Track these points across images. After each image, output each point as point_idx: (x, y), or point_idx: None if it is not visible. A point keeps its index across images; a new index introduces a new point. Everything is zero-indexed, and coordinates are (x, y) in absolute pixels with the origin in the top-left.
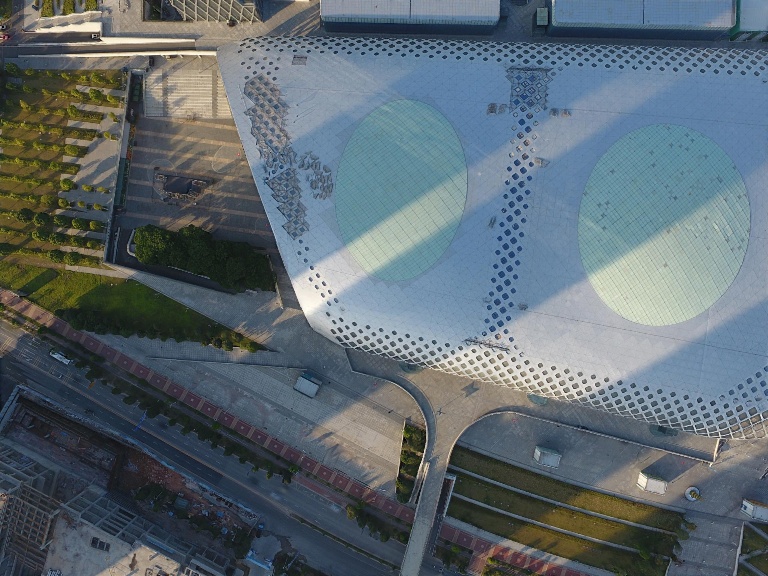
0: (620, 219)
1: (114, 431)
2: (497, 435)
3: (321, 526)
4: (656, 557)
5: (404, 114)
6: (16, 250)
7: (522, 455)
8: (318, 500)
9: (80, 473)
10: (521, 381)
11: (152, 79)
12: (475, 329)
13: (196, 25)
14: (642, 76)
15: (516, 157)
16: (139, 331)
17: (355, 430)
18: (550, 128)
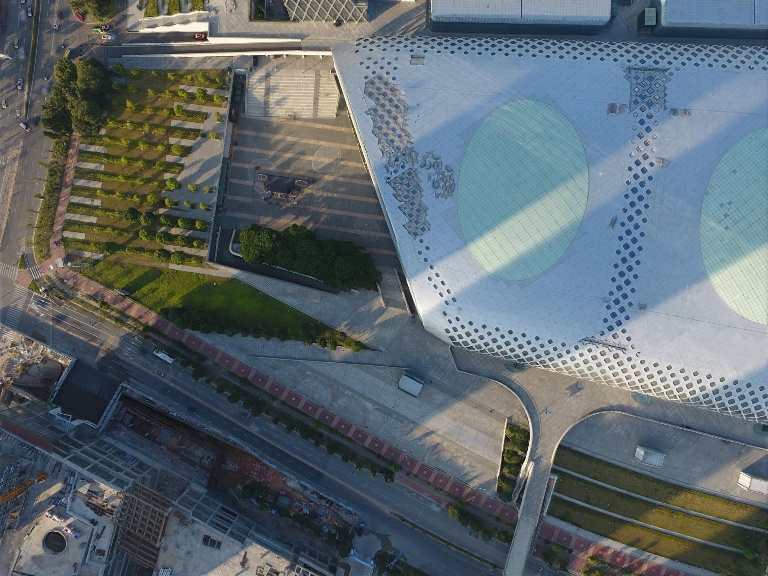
0: (743, 219)
1: (216, 429)
2: (598, 434)
3: (421, 525)
4: (760, 556)
5: (525, 114)
6: (120, 249)
7: (623, 454)
8: (418, 499)
9: (180, 471)
10: (634, 380)
11: (255, 79)
12: (593, 328)
13: (302, 25)
14: (759, 76)
15: (637, 157)
16: (243, 330)
17: (456, 429)
18: (670, 128)
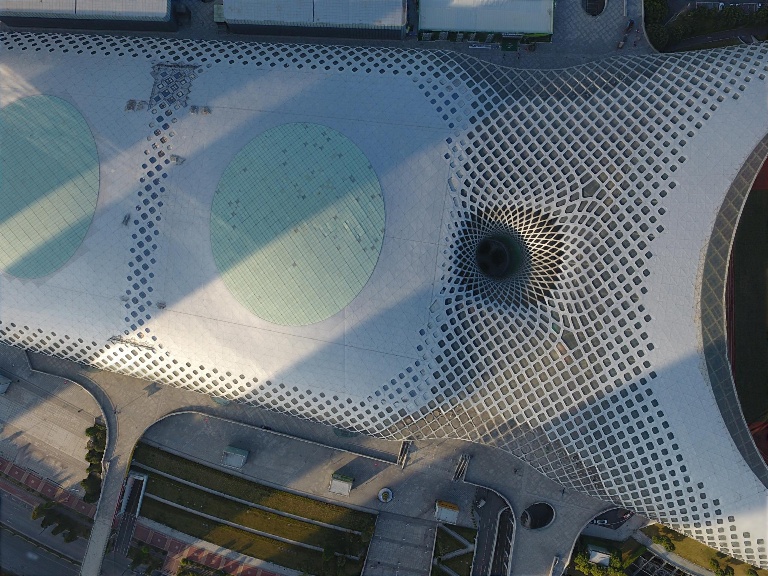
0: (249, 218)
1: None
2: (189, 435)
3: (13, 526)
4: None
5: (38, 110)
6: None
7: (214, 455)
8: (10, 500)
9: None
10: (177, 381)
11: None
12: (117, 328)
13: None
14: (291, 74)
15: (152, 154)
16: None
17: (46, 429)
18: (188, 125)
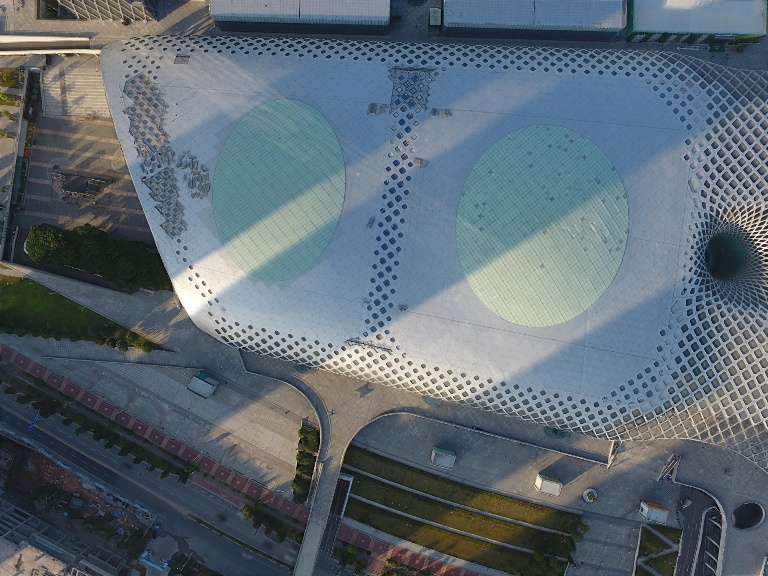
0: (497, 220)
1: (10, 431)
2: (394, 436)
3: (219, 527)
4: (550, 559)
5: (283, 114)
6: None
7: (419, 456)
8: (216, 501)
9: None
10: (407, 382)
11: (49, 77)
12: (356, 329)
13: (91, 24)
14: (525, 77)
15: (395, 157)
16: (33, 330)
17: (252, 430)
18: (430, 128)
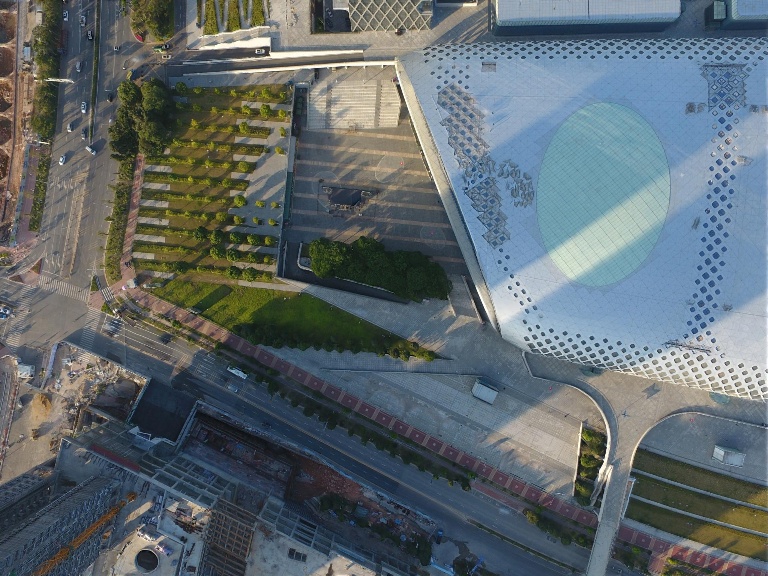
0: None
1: (292, 443)
2: (675, 435)
3: (498, 531)
4: None
5: (602, 117)
6: (189, 268)
7: (701, 455)
8: (495, 505)
9: (257, 485)
10: (717, 382)
11: (316, 92)
12: (676, 332)
13: (364, 35)
14: None
15: (718, 156)
16: (316, 344)
17: (531, 435)
18: (751, 125)
